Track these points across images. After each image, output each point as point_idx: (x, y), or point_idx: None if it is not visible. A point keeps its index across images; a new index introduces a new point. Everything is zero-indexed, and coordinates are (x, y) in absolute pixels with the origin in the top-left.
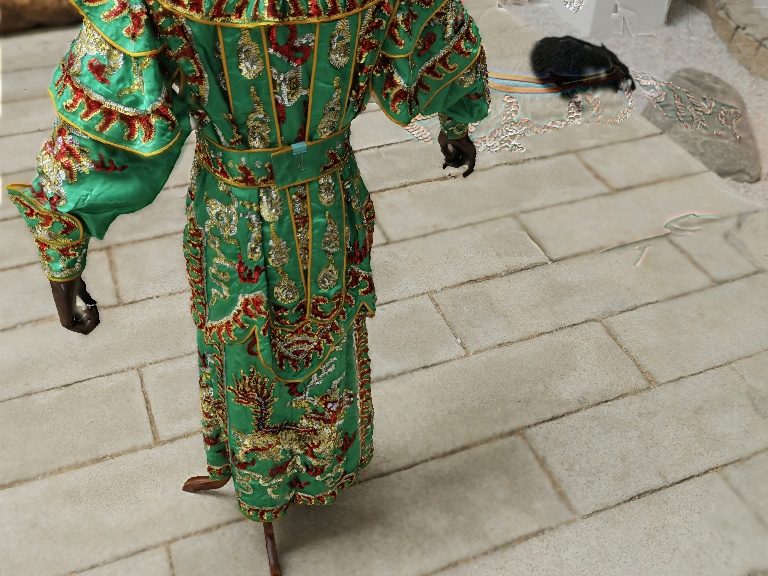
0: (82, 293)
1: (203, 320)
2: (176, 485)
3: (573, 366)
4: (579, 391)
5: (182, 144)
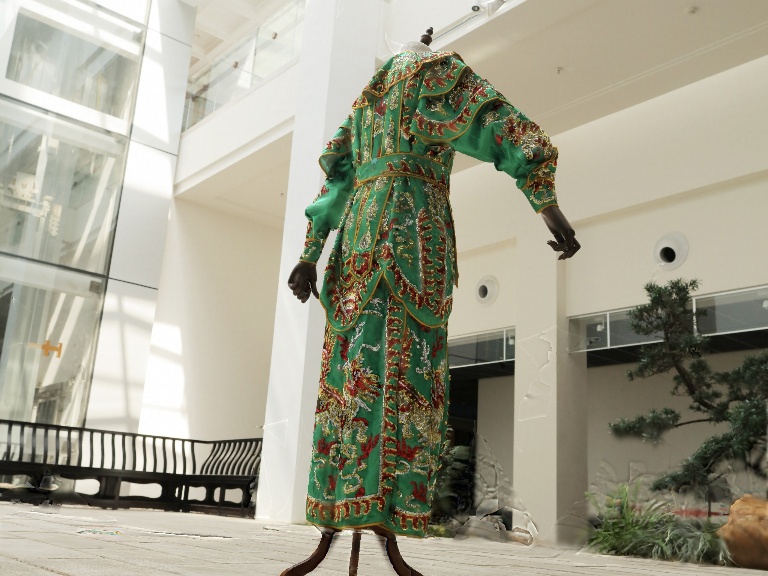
0: (311, 281)
1: None
2: None
3: None
4: None
5: (348, 176)
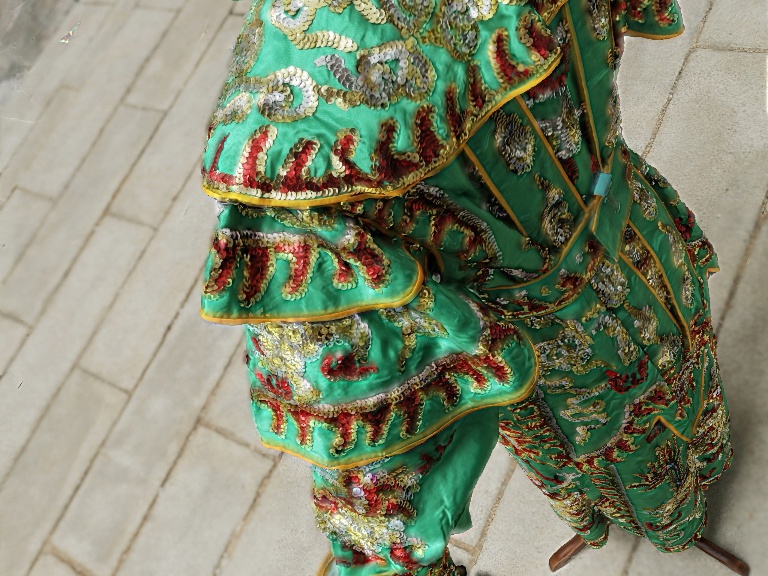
0: None
1: (566, 459)
2: (541, 573)
3: (729, 111)
4: (764, 128)
5: None
